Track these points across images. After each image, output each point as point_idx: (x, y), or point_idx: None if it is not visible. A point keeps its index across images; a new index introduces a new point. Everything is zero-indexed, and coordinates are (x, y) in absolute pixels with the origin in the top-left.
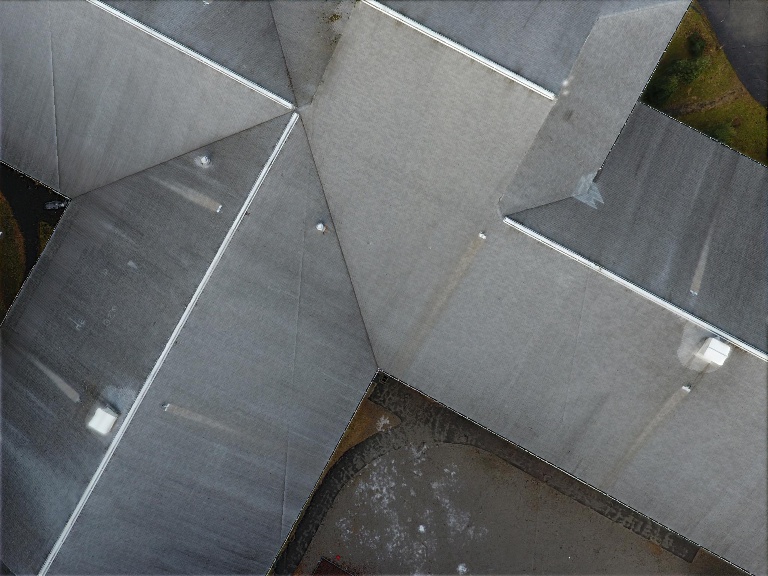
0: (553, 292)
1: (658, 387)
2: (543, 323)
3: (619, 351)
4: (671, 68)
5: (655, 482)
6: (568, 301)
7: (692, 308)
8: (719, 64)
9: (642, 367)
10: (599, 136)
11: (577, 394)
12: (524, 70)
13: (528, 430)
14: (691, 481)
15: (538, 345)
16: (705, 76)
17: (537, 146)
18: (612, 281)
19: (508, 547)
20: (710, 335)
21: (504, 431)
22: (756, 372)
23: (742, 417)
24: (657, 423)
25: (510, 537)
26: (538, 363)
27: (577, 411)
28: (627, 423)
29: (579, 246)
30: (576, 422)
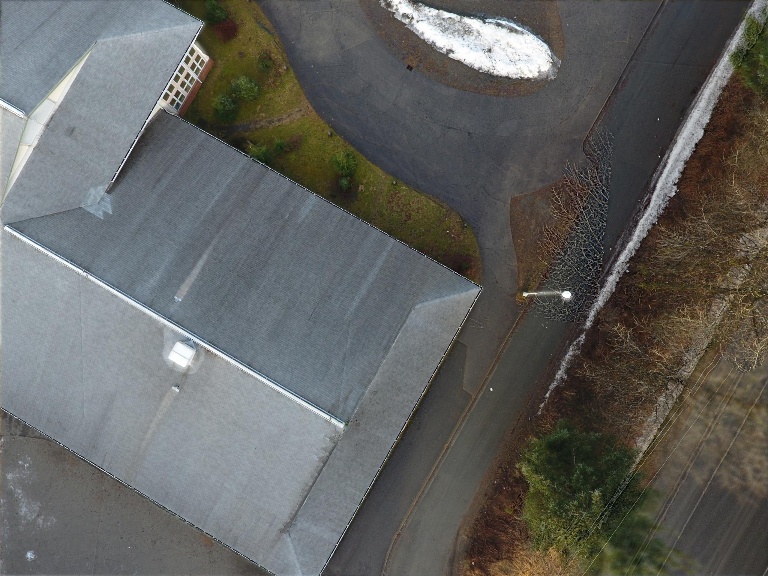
0: (55, 296)
1: (153, 387)
2: (53, 325)
3: (117, 352)
4: (229, 87)
5: (167, 476)
6: (69, 305)
7: (171, 313)
8: (287, 83)
9: (137, 368)
10: (107, 151)
11: (91, 392)
12: (1, 90)
13: (59, 425)
14: (195, 476)
15: (52, 345)
16: (273, 94)
17: (37, 160)
18: (100, 287)
19: (73, 536)
20: (184, 339)
21: (40, 426)
22: (228, 374)
23: (224, 417)
24: (159, 421)
25: (75, 527)
26: (55, 362)
27: (94, 408)
28: (135, 420)
29: (73, 253)
30: (95, 418)
